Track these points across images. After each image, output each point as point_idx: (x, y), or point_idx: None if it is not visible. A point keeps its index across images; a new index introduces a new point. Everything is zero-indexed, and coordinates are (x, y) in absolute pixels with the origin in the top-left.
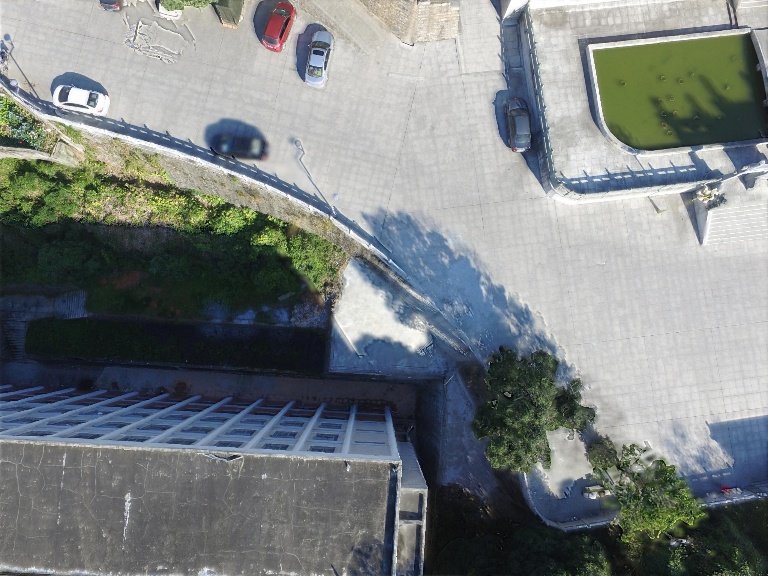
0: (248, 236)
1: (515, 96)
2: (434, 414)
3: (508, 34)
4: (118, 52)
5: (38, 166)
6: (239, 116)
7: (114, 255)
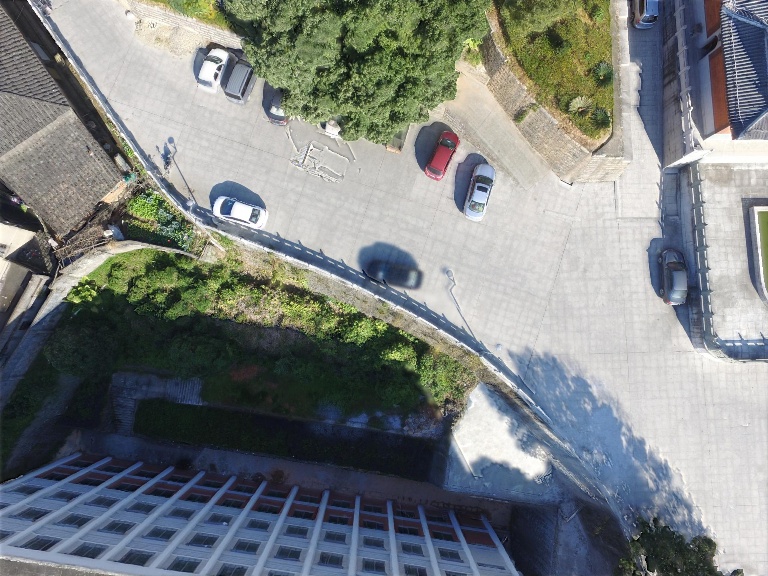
0: (375, 346)
1: (670, 245)
2: (540, 538)
3: (667, 181)
4: (279, 165)
5: (179, 261)
6: (393, 241)
7: (237, 349)
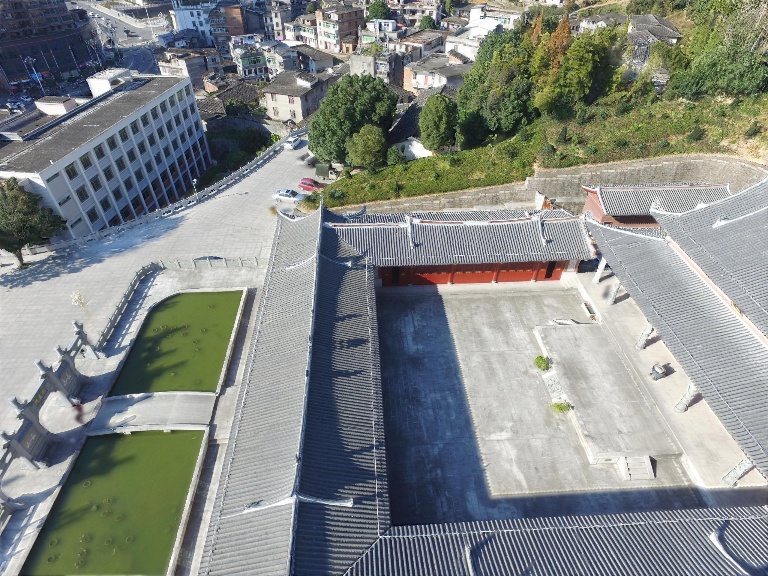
0: None
1: None
2: None
3: None
4: None
5: None
6: (270, 178)
7: None
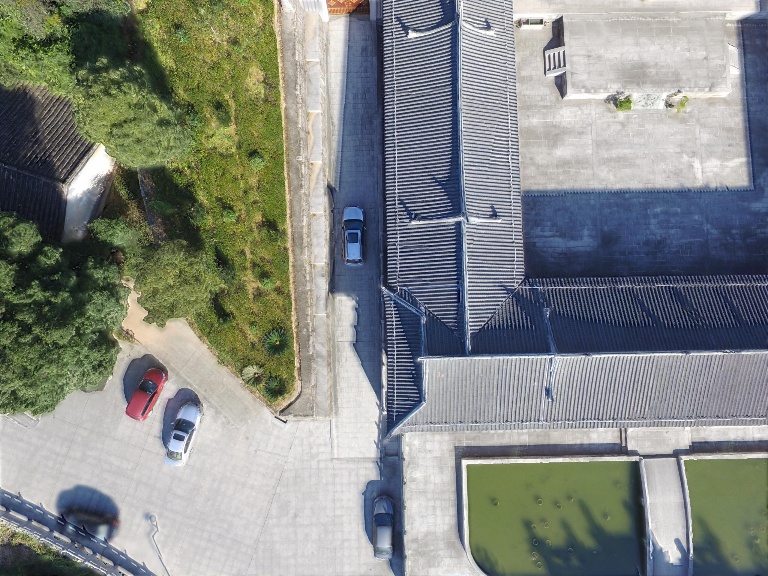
0: None
1: (387, 488)
2: None
3: None
4: None
5: None
6: (96, 483)
7: None
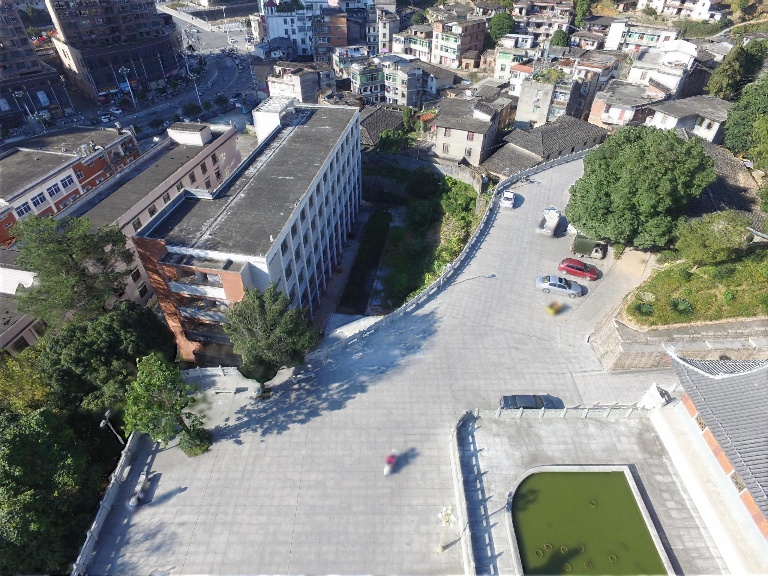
0: None
1: None
2: None
3: None
4: None
5: (474, 200)
6: (509, 252)
7: None
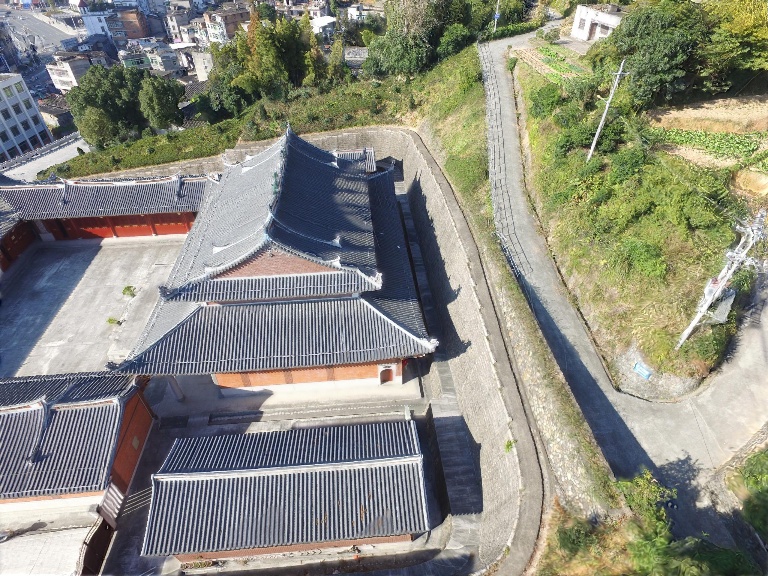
0: None
1: None
2: None
3: None
4: None
5: None
6: (53, 161)
7: None
